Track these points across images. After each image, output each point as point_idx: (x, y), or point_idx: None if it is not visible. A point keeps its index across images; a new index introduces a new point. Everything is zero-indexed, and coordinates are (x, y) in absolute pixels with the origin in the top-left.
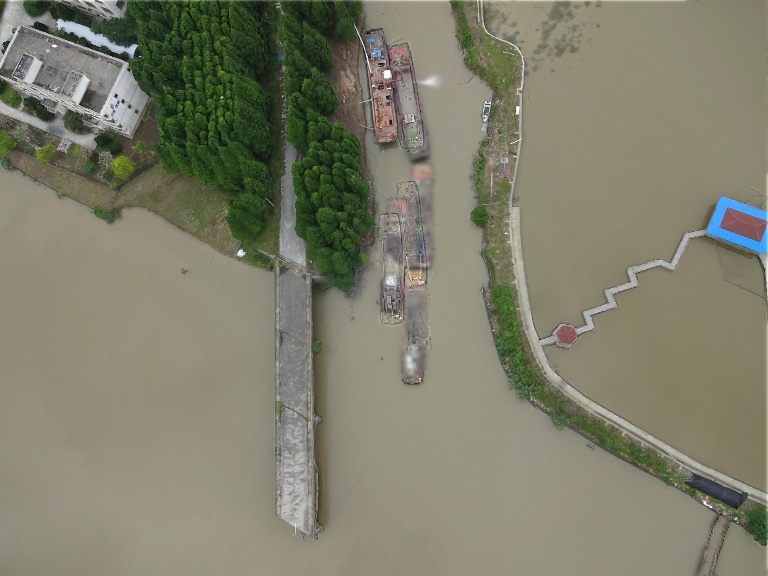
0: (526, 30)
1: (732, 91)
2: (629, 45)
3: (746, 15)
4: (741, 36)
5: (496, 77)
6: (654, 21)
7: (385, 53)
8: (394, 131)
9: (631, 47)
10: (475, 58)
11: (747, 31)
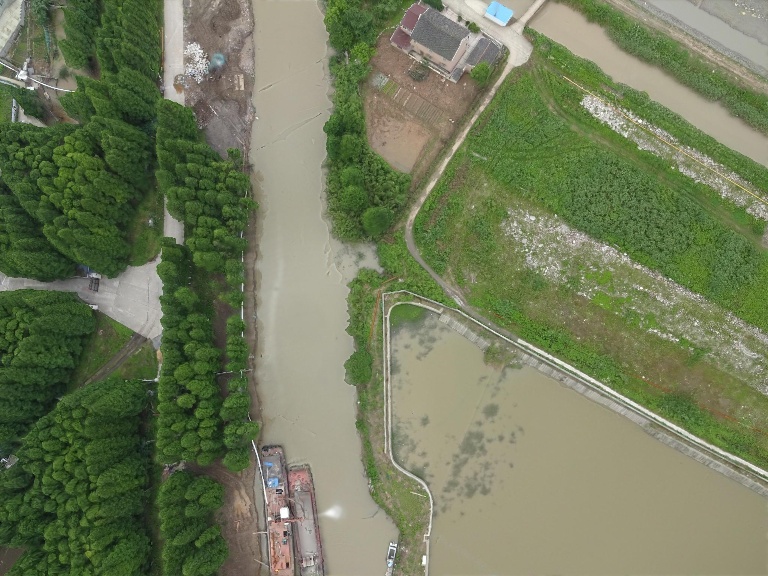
0: (436, 462)
1: (643, 562)
2: (542, 490)
3: (661, 465)
4: (655, 491)
5: (402, 522)
6: (569, 464)
7: (283, 478)
8: (291, 575)
9: (544, 493)
10: (380, 497)
11: (661, 485)
